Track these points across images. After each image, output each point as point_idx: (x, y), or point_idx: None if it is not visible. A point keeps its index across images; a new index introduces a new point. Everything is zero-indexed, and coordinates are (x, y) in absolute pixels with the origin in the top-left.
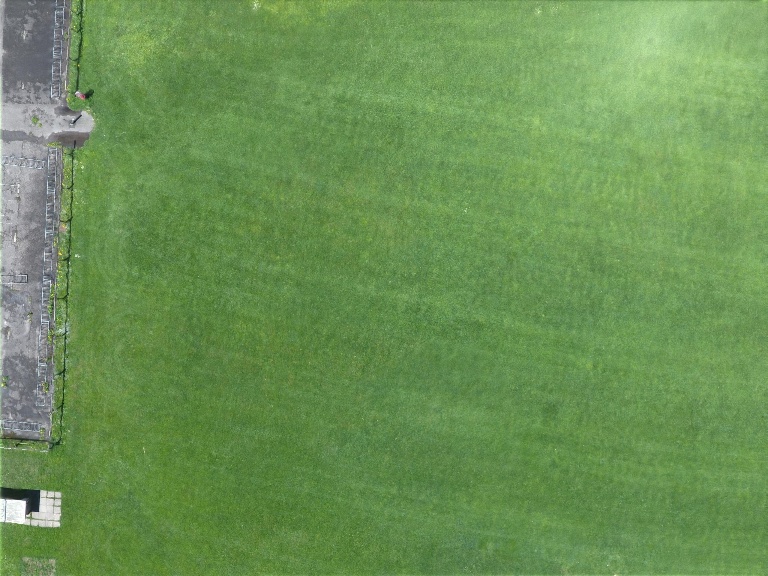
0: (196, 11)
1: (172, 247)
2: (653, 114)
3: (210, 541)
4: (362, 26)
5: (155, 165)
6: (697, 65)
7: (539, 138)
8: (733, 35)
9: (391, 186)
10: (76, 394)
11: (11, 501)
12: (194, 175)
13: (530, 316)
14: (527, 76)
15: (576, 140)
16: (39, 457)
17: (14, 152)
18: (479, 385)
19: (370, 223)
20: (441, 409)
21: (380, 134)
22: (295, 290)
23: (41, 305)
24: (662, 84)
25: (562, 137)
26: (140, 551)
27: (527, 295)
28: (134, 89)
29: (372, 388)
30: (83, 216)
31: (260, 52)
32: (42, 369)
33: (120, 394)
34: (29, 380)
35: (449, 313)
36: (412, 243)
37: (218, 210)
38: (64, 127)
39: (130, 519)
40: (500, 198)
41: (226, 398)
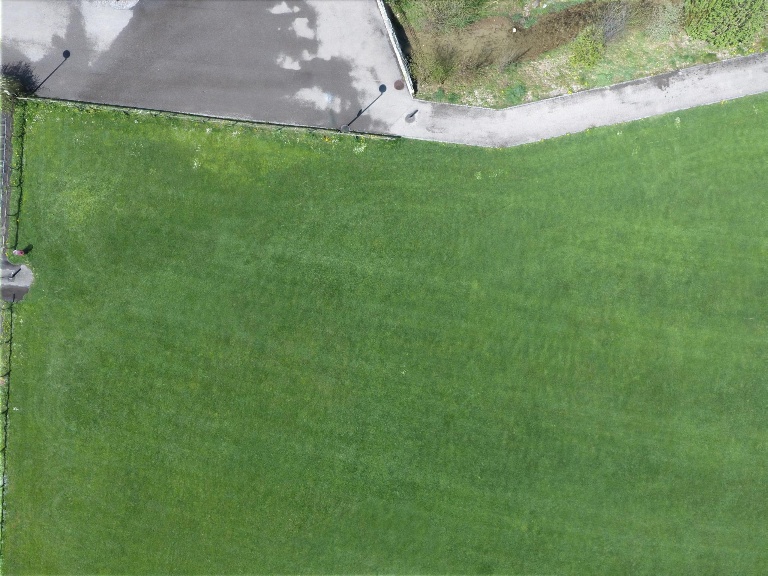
0: (136, 168)
1: (110, 403)
2: (590, 281)
3: None
4: (302, 188)
5: (94, 321)
6: (635, 234)
7: (477, 303)
8: (671, 205)
9: (329, 347)
10: (14, 545)
11: None
12: (133, 332)
13: (466, 478)
14: (465, 242)
15: (513, 306)
16: None
17: None
18: (415, 545)
19: (308, 383)
20: (377, 568)
21: (319, 295)
22: (233, 447)
23: None
24: (600, 252)
25: (499, 303)
26: None
27: (463, 457)
28: (73, 245)
29: (309, 546)
30: (22, 370)
31: (200, 211)
32: None
33: (58, 546)
34: None
35: (386, 473)
36: (350, 403)
37: (157, 367)
38: (3, 281)
39: None
40: (438, 361)
41: (163, 552)
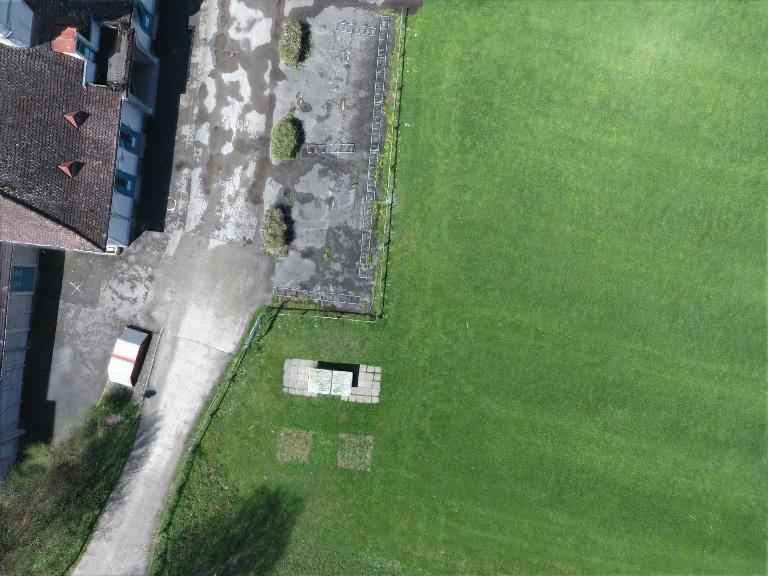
0: None
1: (506, 116)
2: None
3: (533, 419)
4: None
5: (491, 33)
6: None
7: None
8: None
9: (733, 57)
10: (400, 266)
11: (338, 372)
12: (531, 44)
13: None
14: None
15: None
16: (360, 331)
17: (346, 19)
18: None
19: (710, 95)
20: None
21: (724, 4)
22: (631, 162)
23: (367, 175)
24: None
25: None
26: (460, 429)
27: None
28: None
29: (707, 263)
30: (414, 84)
31: None
32: (365, 240)
33: (445, 267)
34: (352, 252)
35: None
36: (752, 115)
37: (554, 80)
38: None
39: (450, 396)
40: None
41: (555, 272)
